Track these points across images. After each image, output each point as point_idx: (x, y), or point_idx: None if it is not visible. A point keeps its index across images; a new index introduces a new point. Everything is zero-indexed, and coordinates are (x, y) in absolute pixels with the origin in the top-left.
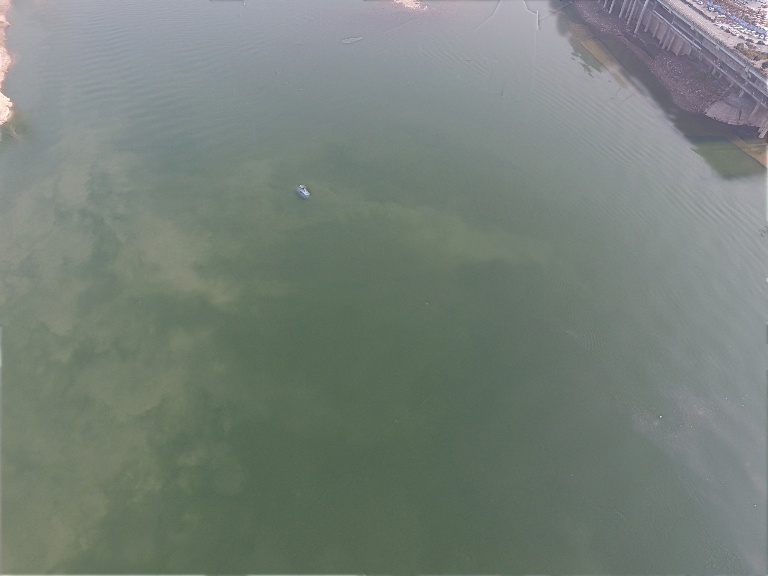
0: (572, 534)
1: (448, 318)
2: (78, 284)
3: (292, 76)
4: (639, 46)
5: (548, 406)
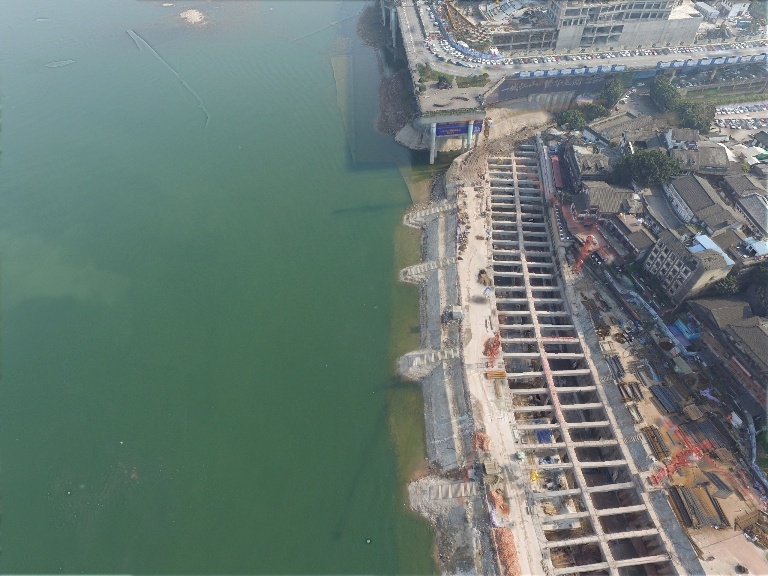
0: None
1: None
2: None
3: (24, 100)
4: (387, 61)
5: None
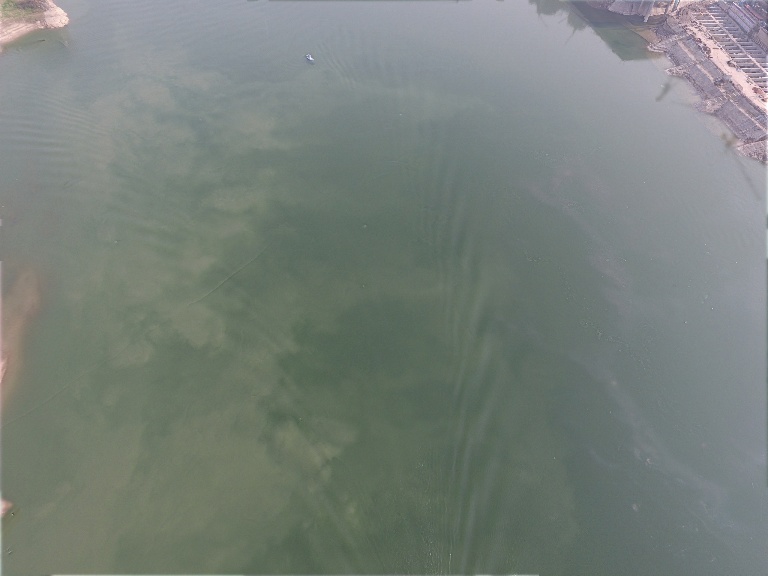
0: (489, 207)
1: (415, 121)
2: (153, 113)
3: None
4: None
5: (477, 152)
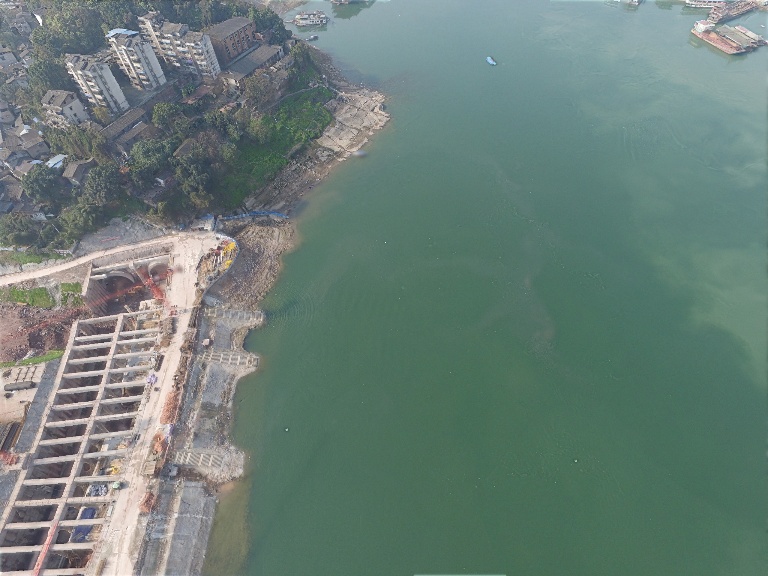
0: (650, 368)
1: None
2: None
3: None
4: None
5: (704, 470)
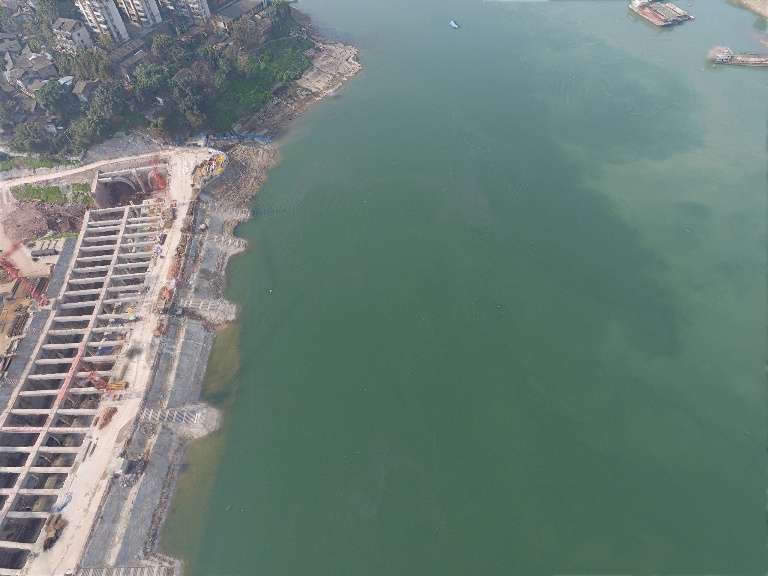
0: (564, 251)
1: (713, 412)
2: None
3: None
4: None
5: (594, 311)
